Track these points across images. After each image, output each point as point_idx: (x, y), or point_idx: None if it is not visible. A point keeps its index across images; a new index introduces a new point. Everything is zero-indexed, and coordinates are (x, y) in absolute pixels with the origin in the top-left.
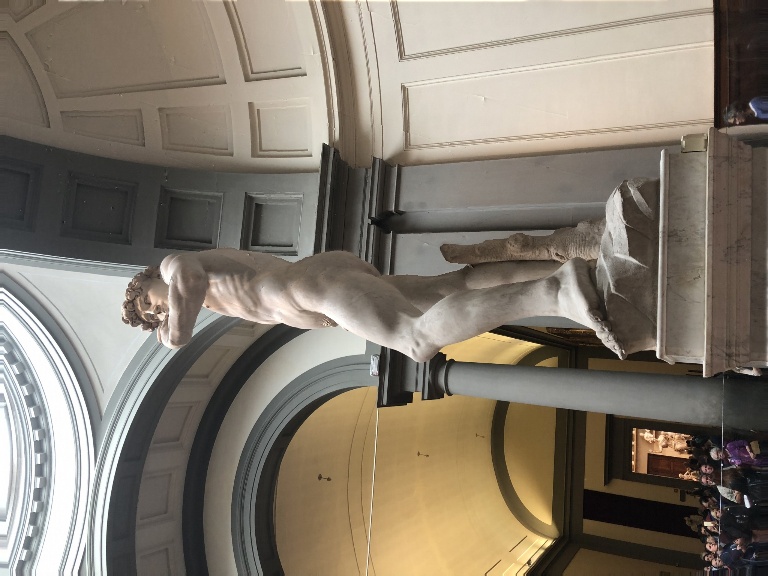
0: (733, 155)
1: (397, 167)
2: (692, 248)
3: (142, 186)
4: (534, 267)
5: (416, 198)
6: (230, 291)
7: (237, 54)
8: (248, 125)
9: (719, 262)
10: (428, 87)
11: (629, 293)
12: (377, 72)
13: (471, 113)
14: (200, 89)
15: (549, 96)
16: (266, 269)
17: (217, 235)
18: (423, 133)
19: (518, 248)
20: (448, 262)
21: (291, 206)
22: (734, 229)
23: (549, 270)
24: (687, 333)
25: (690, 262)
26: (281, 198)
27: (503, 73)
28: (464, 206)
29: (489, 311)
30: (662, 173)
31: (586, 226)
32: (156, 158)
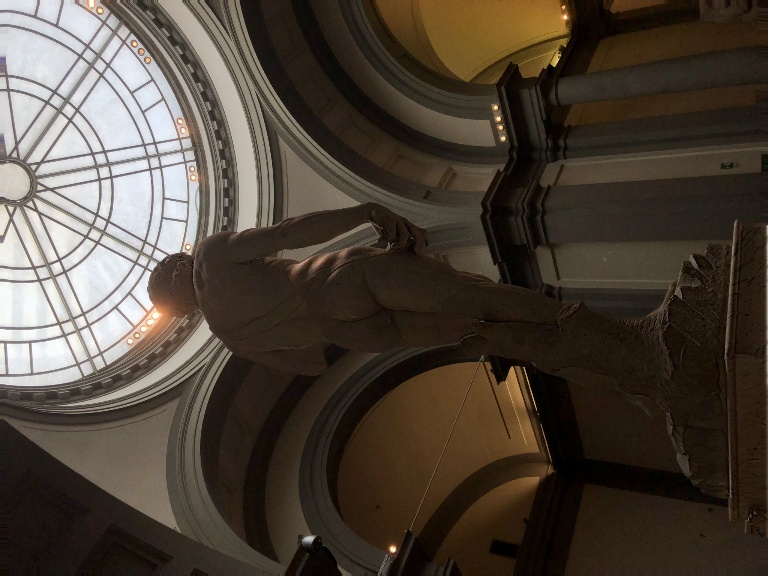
0: None
1: None
2: None
3: None
4: None
5: None
6: None
7: None
8: None
9: None
10: None
11: None
12: None
13: None
14: None
15: None
16: None
17: None
18: None
19: None
20: None
21: None
22: None
23: None
24: None
25: None
26: None
27: None
28: None
29: None
30: None
31: None
32: None
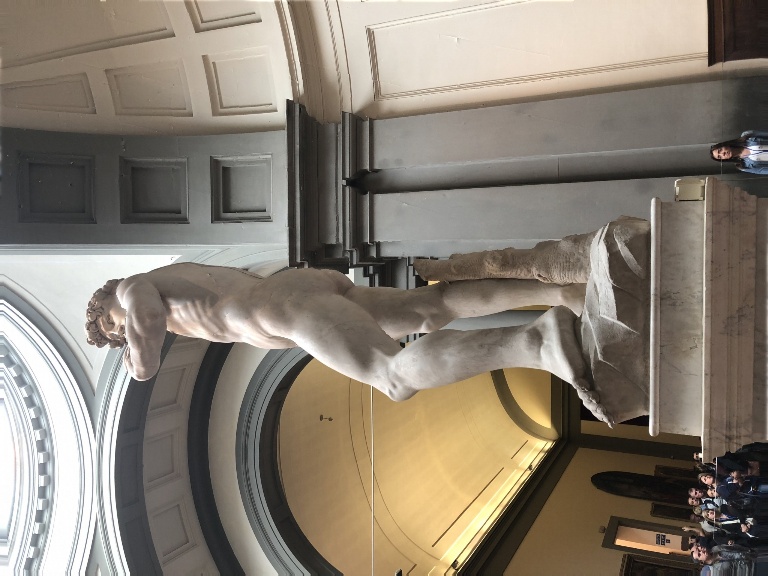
0: (735, 209)
1: (368, 121)
2: (688, 313)
3: (99, 158)
4: (515, 286)
5: (391, 155)
6: (193, 318)
7: (183, 2)
8: (205, 81)
9: (718, 335)
10: (395, 28)
11: (618, 361)
12: (338, 15)
13: (444, 55)
14: (147, 44)
15: (528, 33)
16: (229, 292)
17: (186, 204)
18: (394, 80)
19: (497, 267)
20: (429, 223)
21: (260, 167)
22: (735, 296)
23: (532, 290)
24: (683, 409)
25: (686, 329)
26: (249, 160)
27: (476, 9)
28: (443, 162)
29: (467, 362)
30: (653, 226)
31: (570, 245)
32: (110, 126)
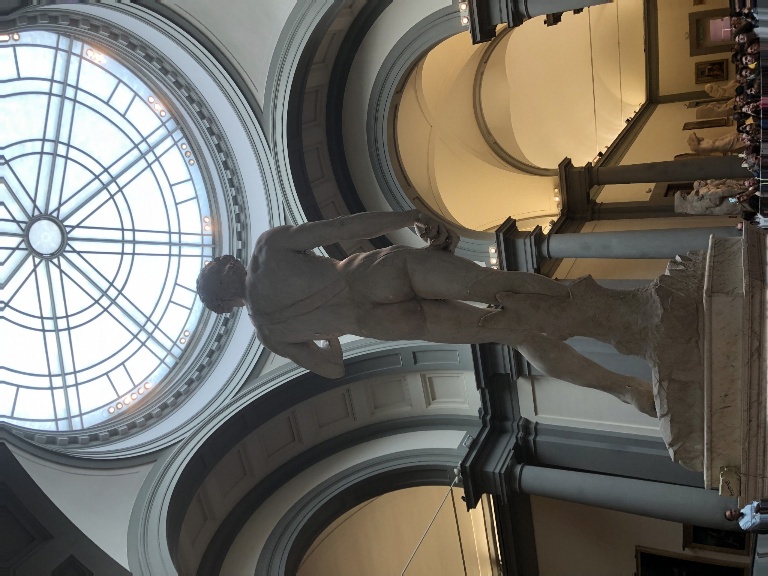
0: None
1: None
2: None
3: None
4: None
5: None
6: None
7: None
8: None
9: None
10: None
11: None
12: None
13: None
14: None
15: None
16: None
17: None
18: None
19: None
20: None
21: None
22: None
23: None
24: None
25: None
26: None
27: None
28: None
29: None
30: None
31: None
32: None
